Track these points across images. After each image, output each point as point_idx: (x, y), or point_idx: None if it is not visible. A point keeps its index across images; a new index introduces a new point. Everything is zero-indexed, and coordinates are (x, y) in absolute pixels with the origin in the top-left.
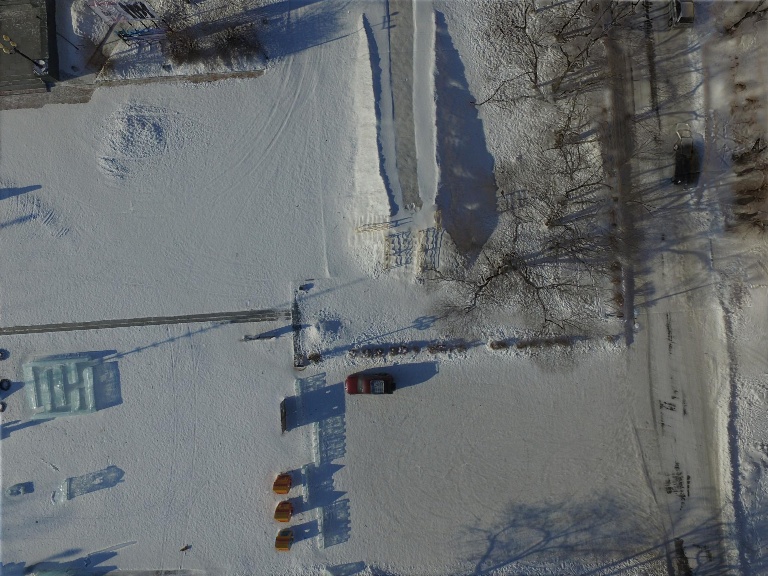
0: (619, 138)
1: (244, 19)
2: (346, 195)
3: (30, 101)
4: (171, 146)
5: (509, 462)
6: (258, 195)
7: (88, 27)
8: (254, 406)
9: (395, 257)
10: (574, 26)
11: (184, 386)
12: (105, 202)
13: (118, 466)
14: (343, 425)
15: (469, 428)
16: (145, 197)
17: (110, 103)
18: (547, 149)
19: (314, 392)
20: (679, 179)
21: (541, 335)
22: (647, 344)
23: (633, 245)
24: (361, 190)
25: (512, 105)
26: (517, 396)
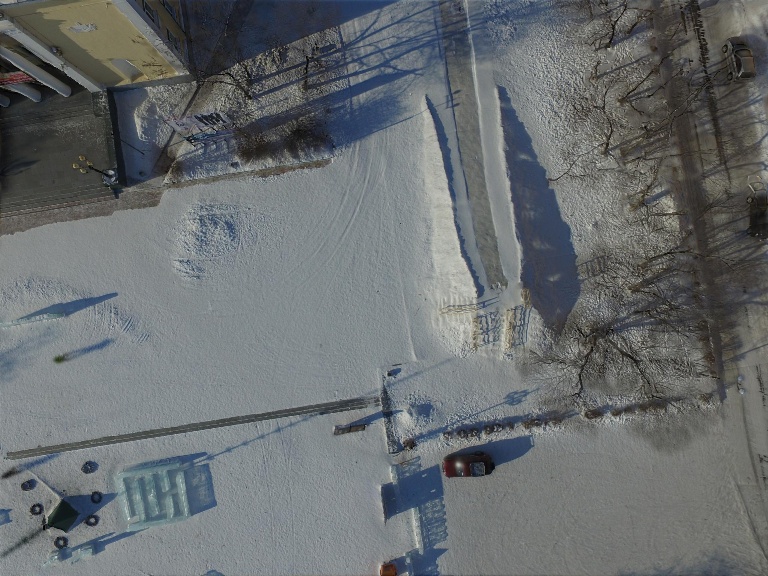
0: (690, 195)
1: (307, 110)
2: (426, 277)
3: (99, 209)
4: (245, 242)
5: (614, 530)
6: (337, 284)
7: (152, 131)
8: (351, 497)
9: (482, 336)
10: (636, 89)
11: (278, 483)
12: (183, 304)
13: (217, 570)
14: (442, 508)
15: (570, 500)
16: (223, 296)
17: (180, 204)
18: (633, 222)
19: (410, 477)
20: (754, 230)
21: (635, 400)
22: (740, 399)
23: (715, 300)
24: (441, 271)
25: (582, 172)
26: (615, 463)
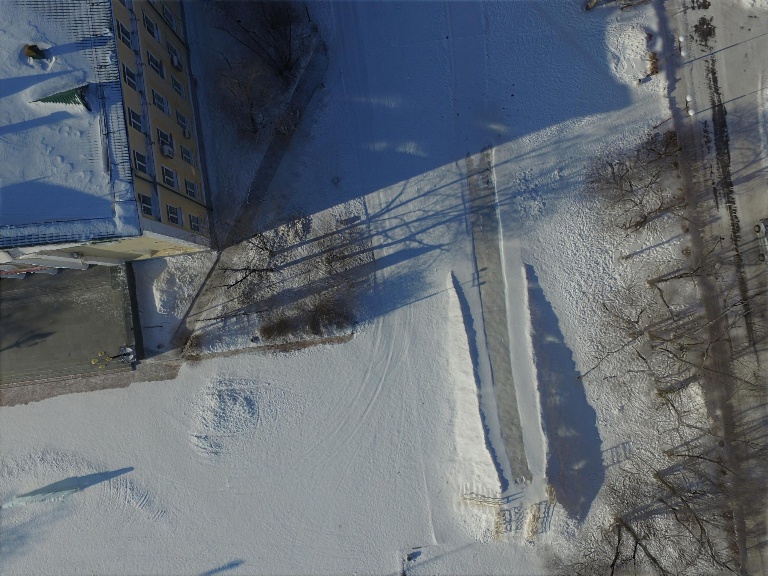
0: (718, 377)
1: (330, 283)
2: (448, 460)
3: (115, 381)
4: (264, 419)
5: None
6: (357, 463)
7: (171, 304)
8: None
9: (505, 525)
10: (666, 269)
11: None
12: (200, 480)
13: None
14: None
15: None
16: (241, 473)
17: (198, 378)
18: None
19: None
20: None
21: None
22: None
23: (741, 485)
24: (464, 456)
25: None
26: None
